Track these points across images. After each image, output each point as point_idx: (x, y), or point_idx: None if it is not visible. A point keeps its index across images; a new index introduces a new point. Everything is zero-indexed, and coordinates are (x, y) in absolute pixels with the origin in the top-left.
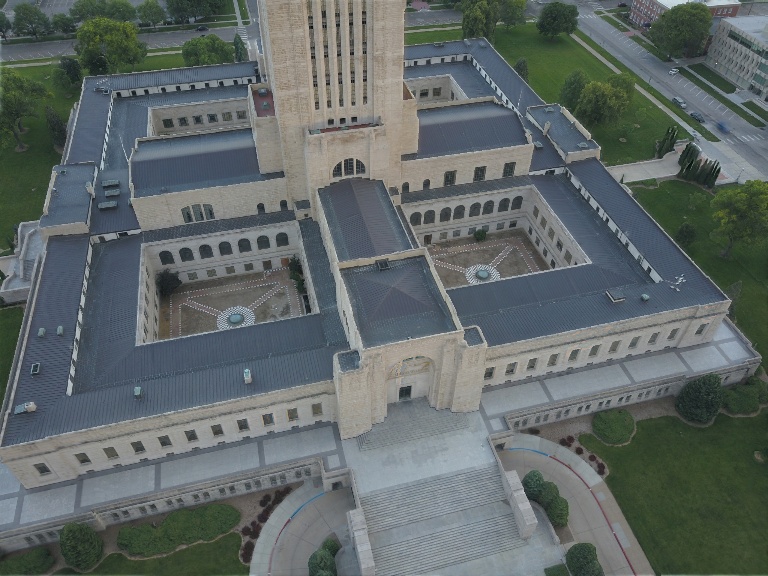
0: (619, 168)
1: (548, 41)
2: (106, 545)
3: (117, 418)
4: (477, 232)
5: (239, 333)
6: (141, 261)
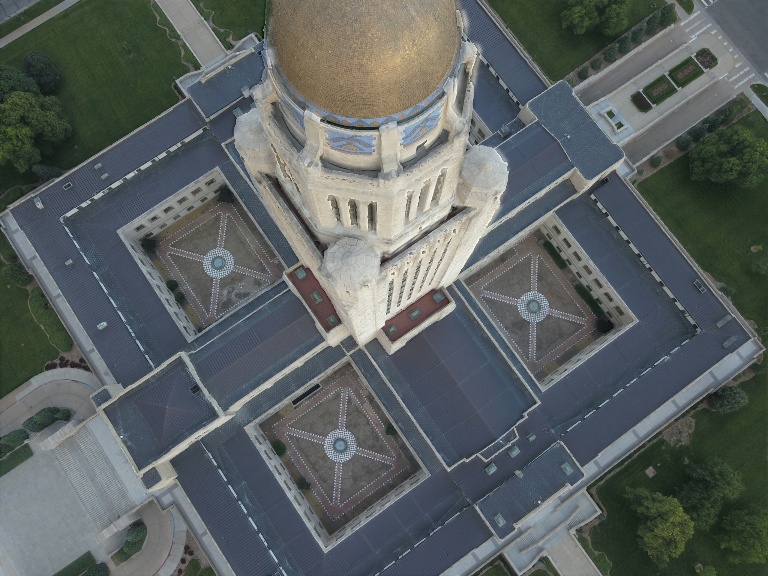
0: (582, 555)
1: None
2: (31, 284)
3: (49, 262)
4: (391, 426)
5: (151, 294)
6: (198, 179)
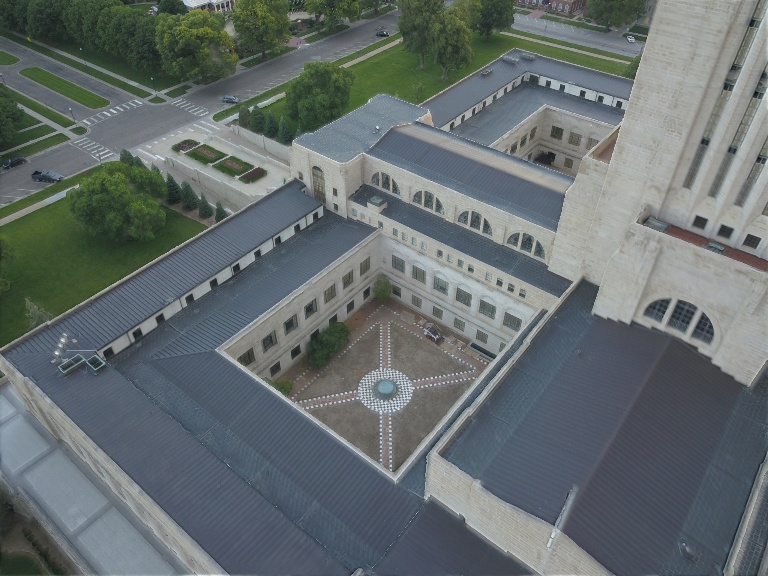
0: None
1: (487, 42)
2: None
3: None
4: None
5: None
6: None
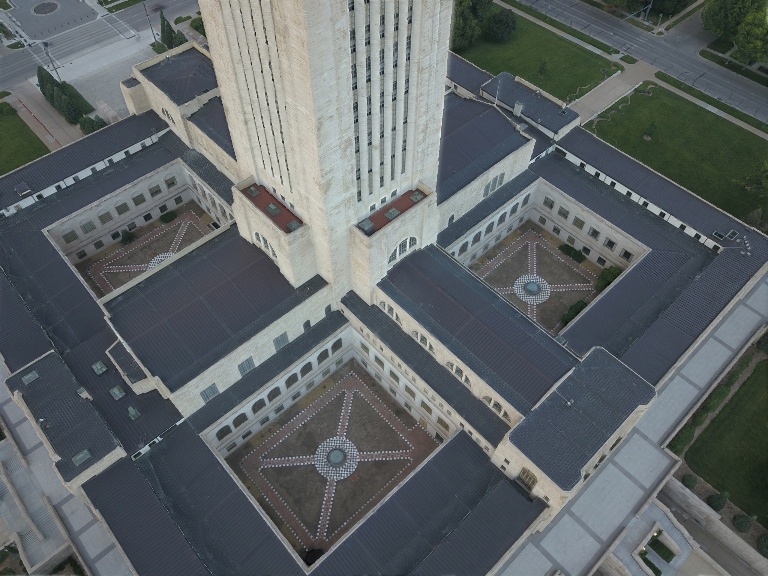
0: None
1: None
2: None
3: None
4: None
5: None
6: None
